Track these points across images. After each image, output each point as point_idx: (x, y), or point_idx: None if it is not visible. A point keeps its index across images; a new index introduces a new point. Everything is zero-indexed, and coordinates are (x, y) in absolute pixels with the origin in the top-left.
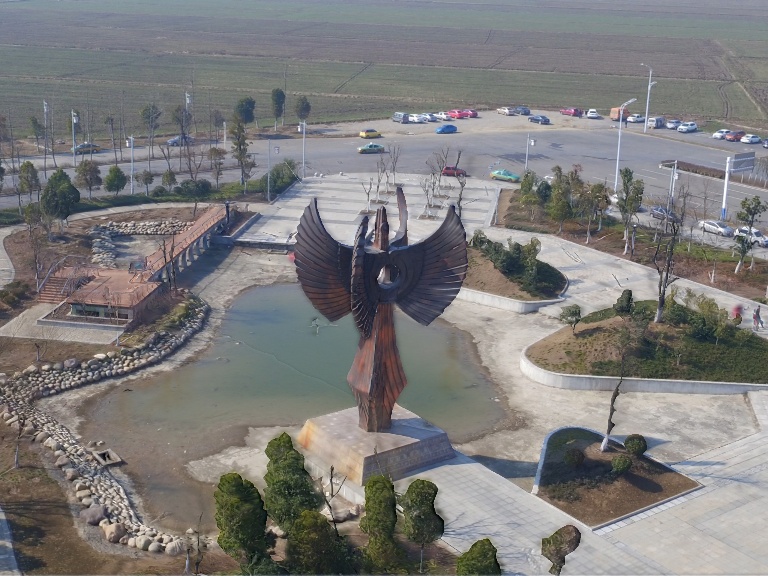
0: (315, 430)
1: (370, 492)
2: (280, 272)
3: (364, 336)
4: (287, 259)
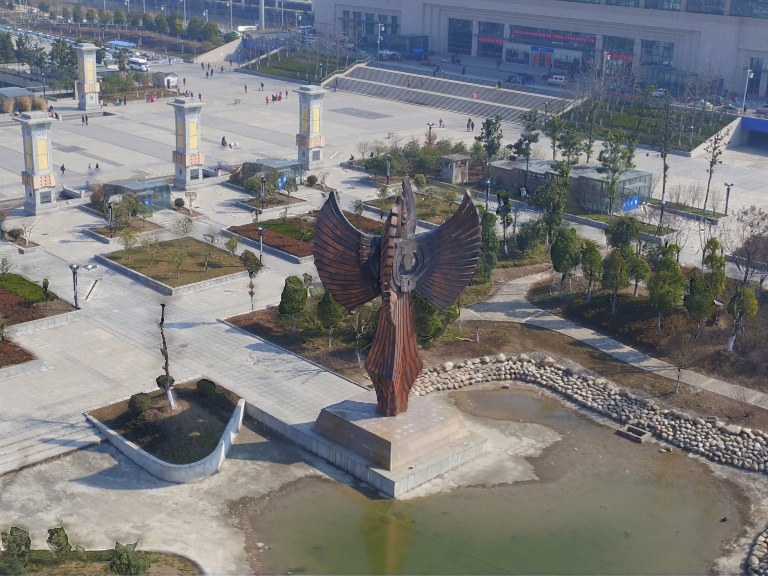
0: None
1: None
2: None
3: None
4: None
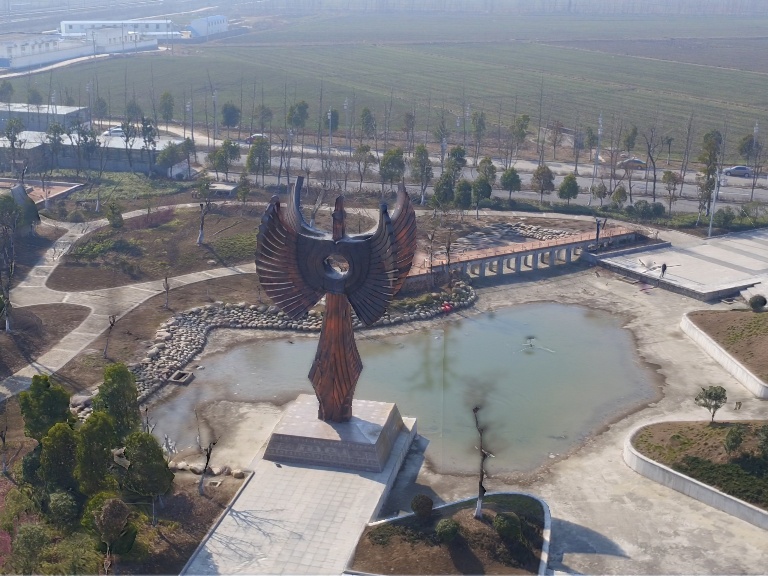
0: None
1: None
2: (596, 296)
3: (289, 316)
4: (626, 288)
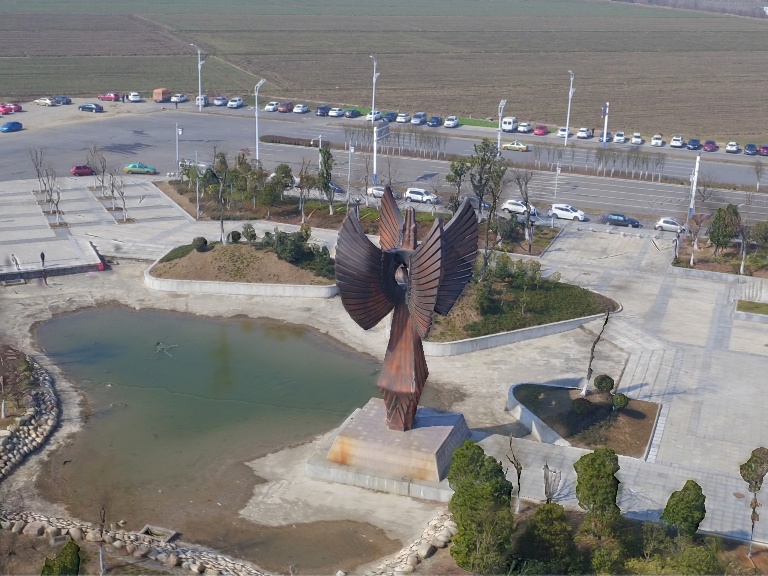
0: (354, 443)
1: (592, 470)
2: (45, 303)
3: (425, 336)
4: (33, 288)
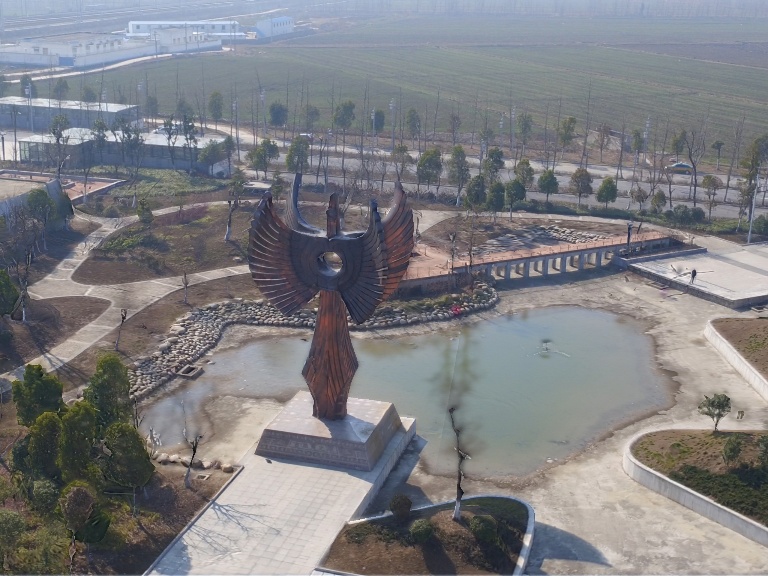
0: None
1: None
2: (621, 301)
3: (282, 312)
4: (654, 293)
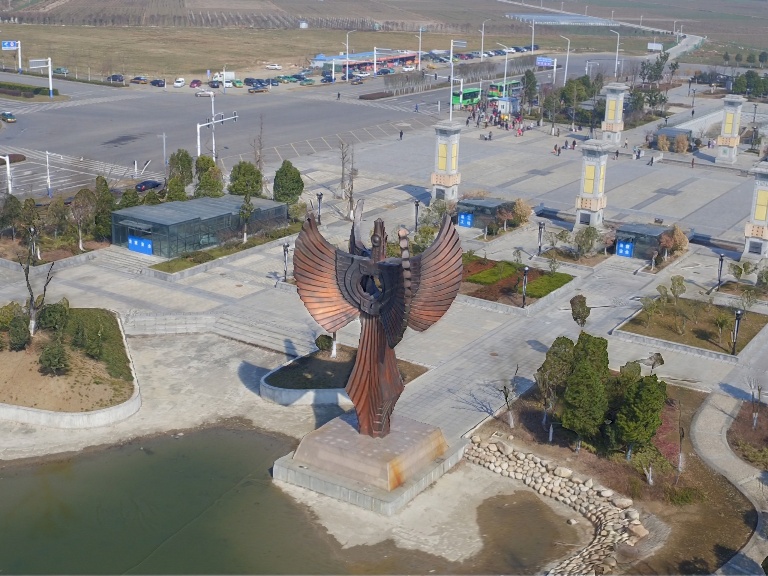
0: None
1: None
2: None
3: None
4: None
